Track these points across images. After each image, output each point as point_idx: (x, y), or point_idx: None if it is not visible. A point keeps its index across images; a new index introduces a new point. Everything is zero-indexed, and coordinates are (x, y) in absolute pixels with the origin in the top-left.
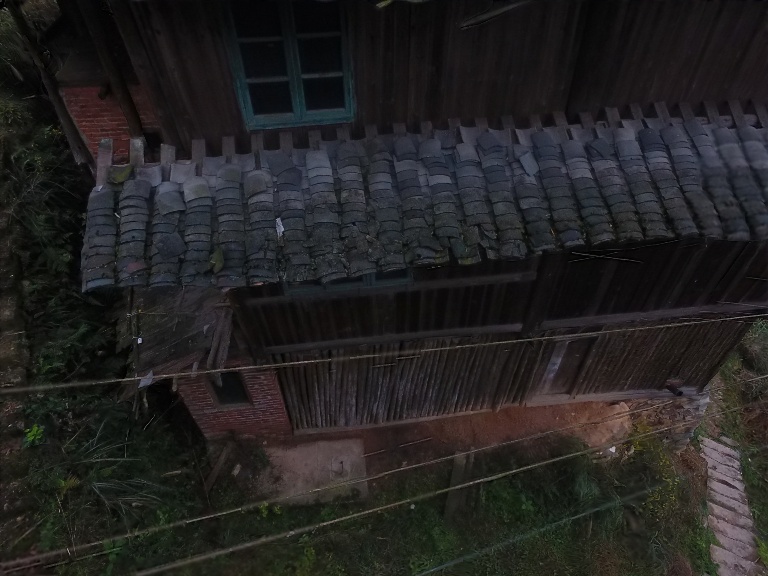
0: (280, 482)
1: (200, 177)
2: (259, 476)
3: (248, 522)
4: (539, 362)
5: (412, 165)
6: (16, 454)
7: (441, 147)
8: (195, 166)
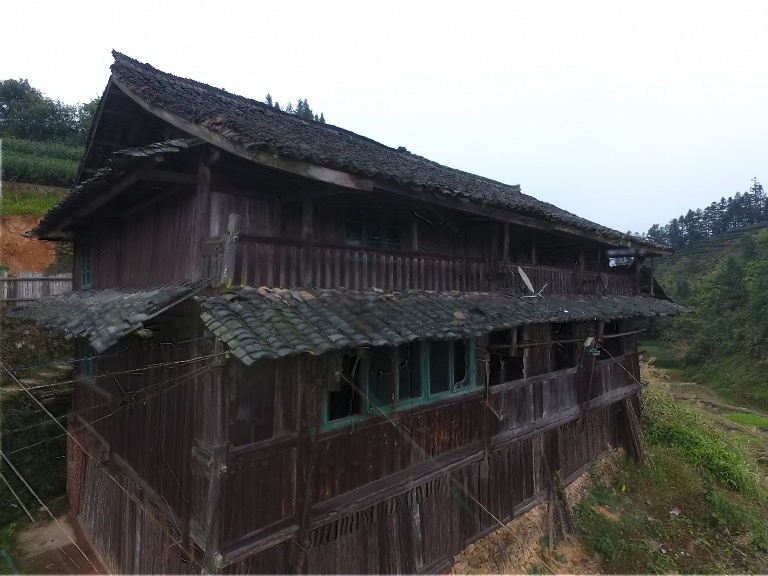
0: (36, 528)
1: None
2: (41, 520)
3: (5, 532)
4: (128, 524)
5: None
6: None
7: None
8: None
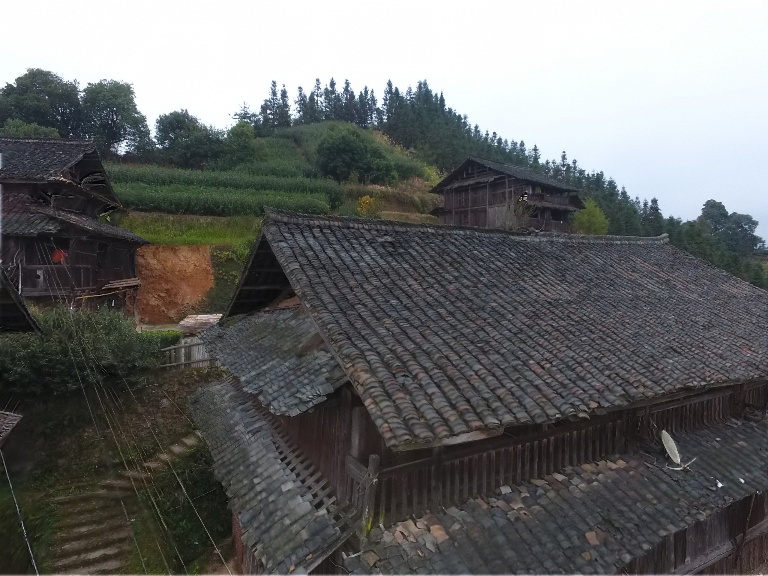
0: (213, 572)
1: (221, 387)
2: (216, 563)
3: (192, 570)
4: None
5: None
6: None
7: (240, 403)
8: None
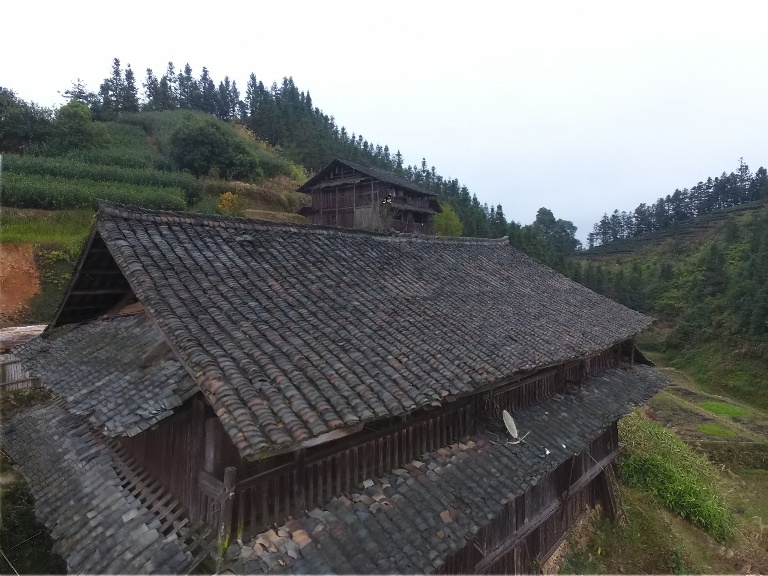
0: None
1: (47, 410)
2: None
3: None
4: None
5: (62, 429)
6: (0, 495)
7: (72, 427)
8: (53, 407)
